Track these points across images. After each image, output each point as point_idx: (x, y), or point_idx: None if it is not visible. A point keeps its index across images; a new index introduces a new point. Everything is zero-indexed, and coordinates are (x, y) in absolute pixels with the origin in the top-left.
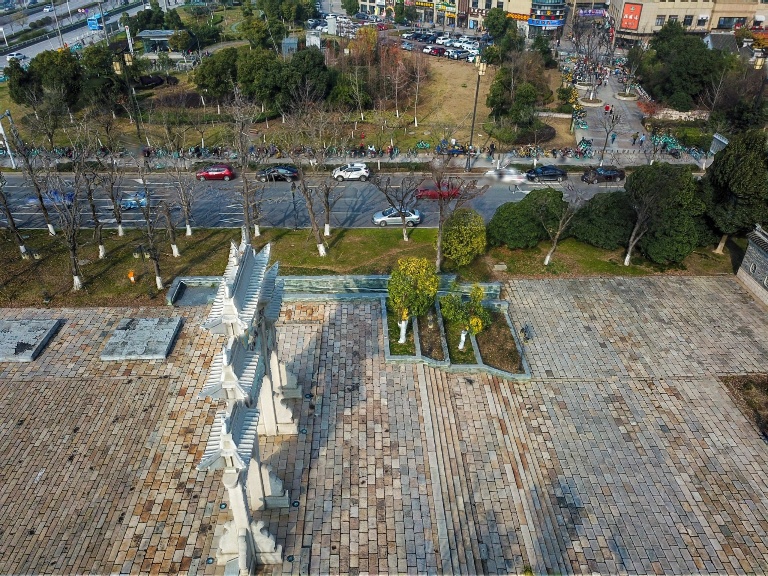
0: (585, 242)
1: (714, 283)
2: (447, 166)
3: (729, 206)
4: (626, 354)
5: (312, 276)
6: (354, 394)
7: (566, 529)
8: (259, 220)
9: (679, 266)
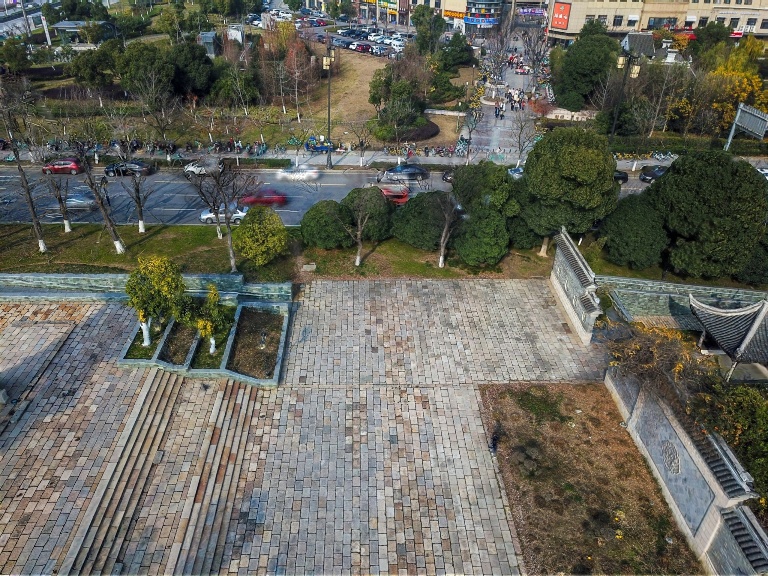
0: (406, 243)
1: (523, 287)
2: (311, 163)
3: (535, 207)
4: (394, 360)
5: (91, 274)
6: (66, 399)
7: (232, 547)
8: (67, 215)
9: (495, 269)
